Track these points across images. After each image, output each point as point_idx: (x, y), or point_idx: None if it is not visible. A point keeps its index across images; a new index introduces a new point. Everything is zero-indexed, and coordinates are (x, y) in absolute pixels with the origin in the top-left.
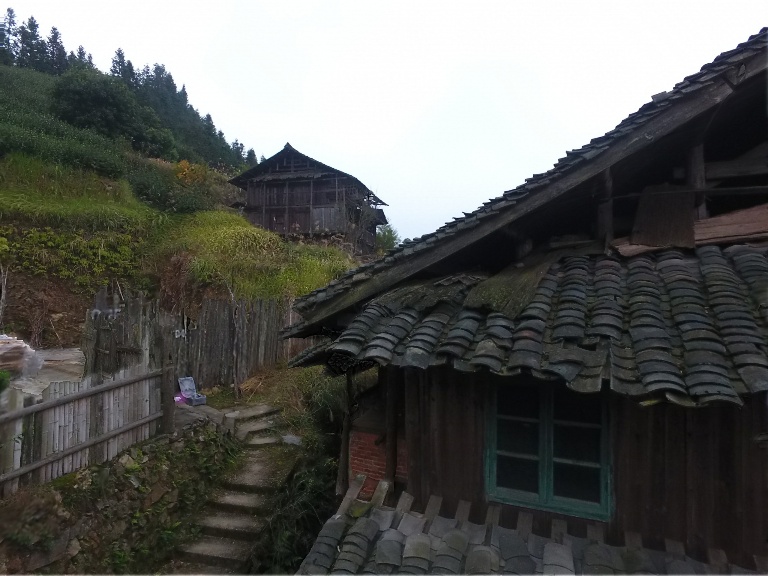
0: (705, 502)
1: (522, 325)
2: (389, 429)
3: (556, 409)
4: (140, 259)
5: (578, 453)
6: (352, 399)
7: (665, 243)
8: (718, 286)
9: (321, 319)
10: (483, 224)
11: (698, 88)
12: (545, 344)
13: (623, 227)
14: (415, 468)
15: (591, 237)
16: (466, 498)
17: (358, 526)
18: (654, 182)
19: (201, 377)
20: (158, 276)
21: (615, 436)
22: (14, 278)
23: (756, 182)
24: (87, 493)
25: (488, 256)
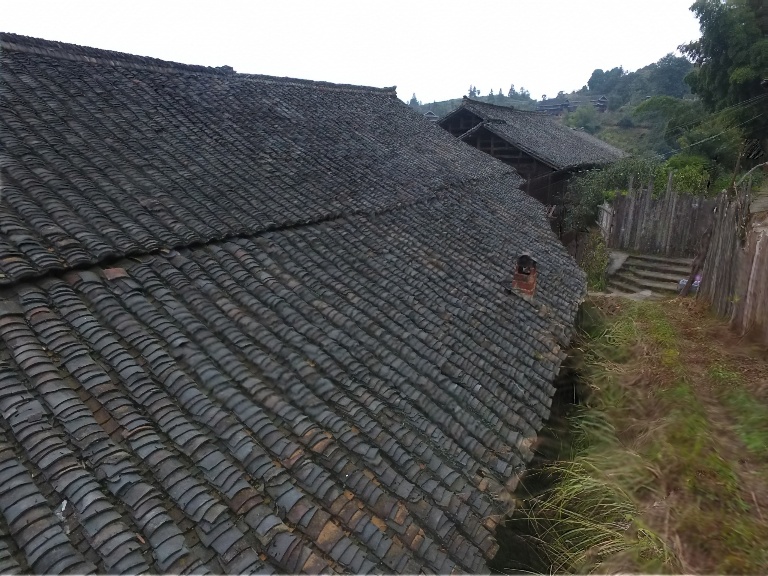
0: None
1: None
2: None
3: None
4: None
5: None
6: None
7: None
8: None
9: None
10: None
11: None
12: None
13: None
14: None
15: None
16: None
17: None
18: None
19: None
20: None
21: None
22: None
23: None
24: None
25: None
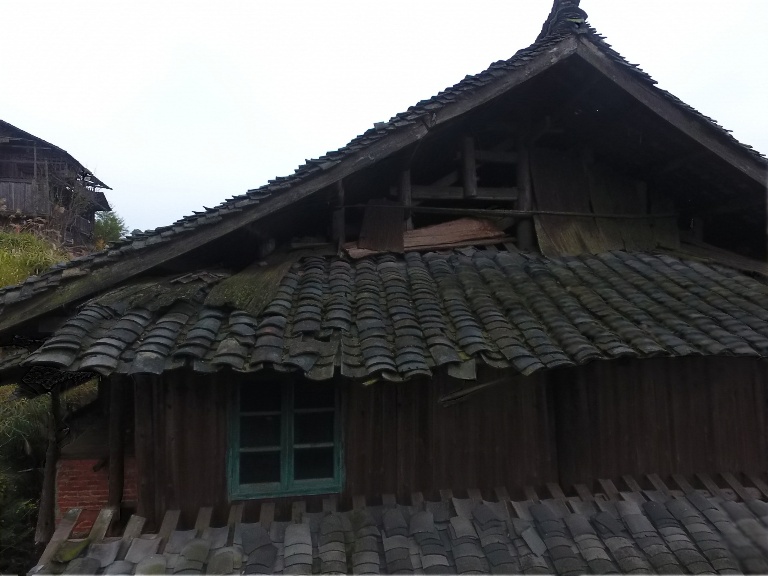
0: (410, 457)
1: (265, 322)
2: (113, 449)
3: (296, 399)
4: None
5: (315, 436)
6: (60, 422)
7: (383, 248)
8: (418, 284)
9: (12, 325)
10: (226, 221)
11: (406, 124)
12: (286, 339)
13: (352, 233)
14: (147, 486)
15: (327, 240)
16: (207, 504)
17: (70, 571)
18: (376, 196)
19: None
20: None
21: (345, 416)
22: None
23: (443, 205)
24: None
25: (231, 253)
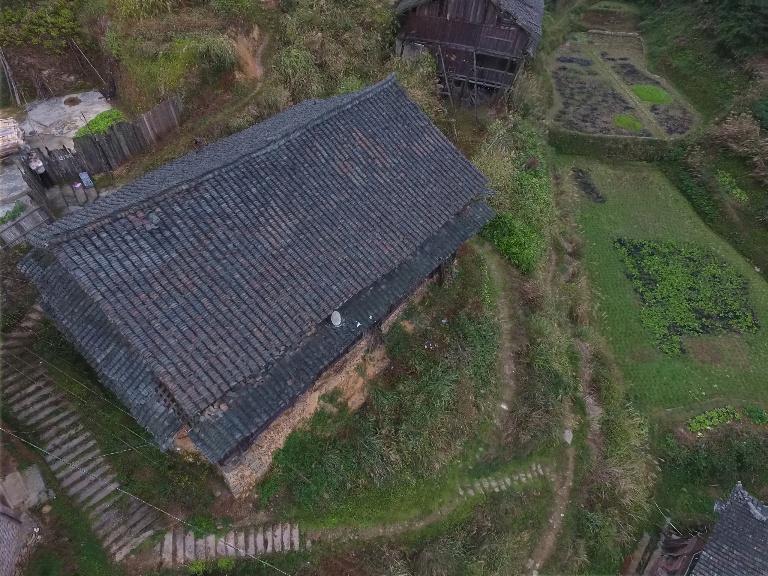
0: None
1: None
2: None
3: None
4: (79, 19)
5: None
6: None
7: None
8: (69, 276)
9: None
10: None
11: None
12: None
13: None
14: None
15: None
16: None
17: None
18: None
19: (91, 170)
20: (95, 37)
21: None
22: (7, 50)
23: None
24: (26, 249)
25: None
